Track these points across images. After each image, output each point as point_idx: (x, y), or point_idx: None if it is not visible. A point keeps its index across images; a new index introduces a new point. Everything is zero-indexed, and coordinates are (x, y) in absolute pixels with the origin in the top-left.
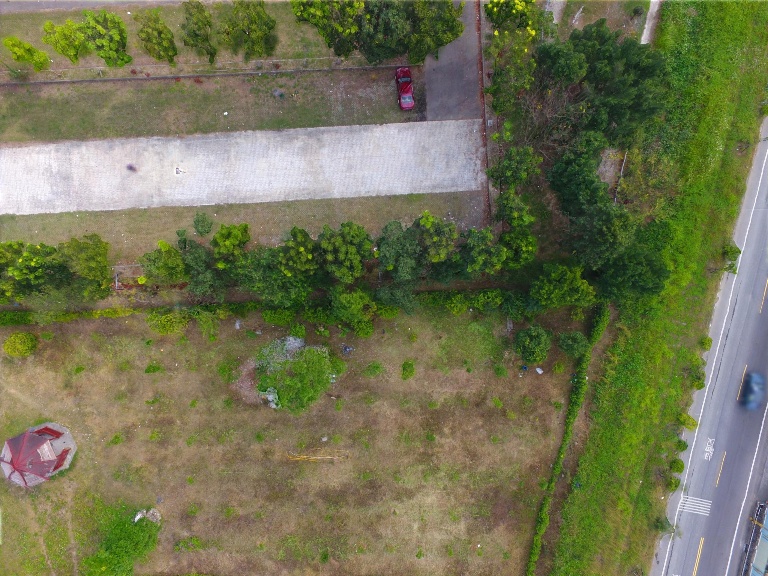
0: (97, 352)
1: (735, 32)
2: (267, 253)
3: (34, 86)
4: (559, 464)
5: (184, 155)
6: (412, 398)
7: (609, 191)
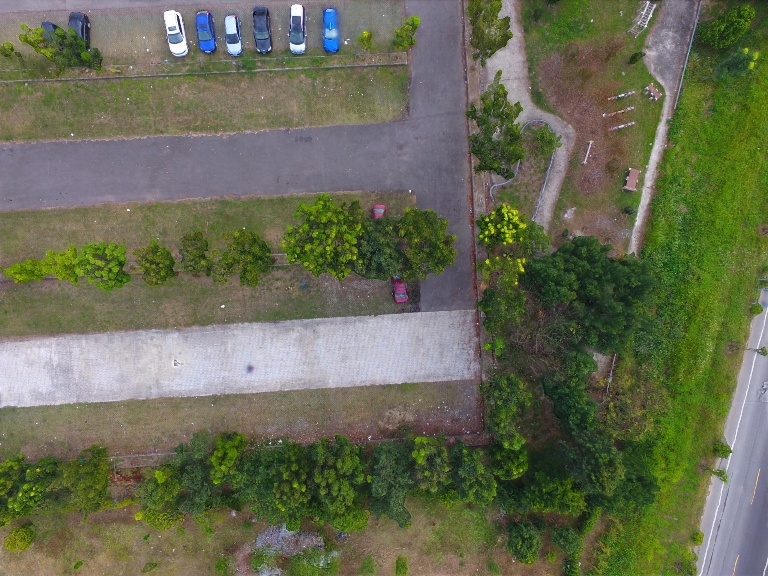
0: (96, 539)
1: (725, 235)
2: (262, 467)
3: (36, 282)
4: None
5: (182, 347)
6: None
7: None
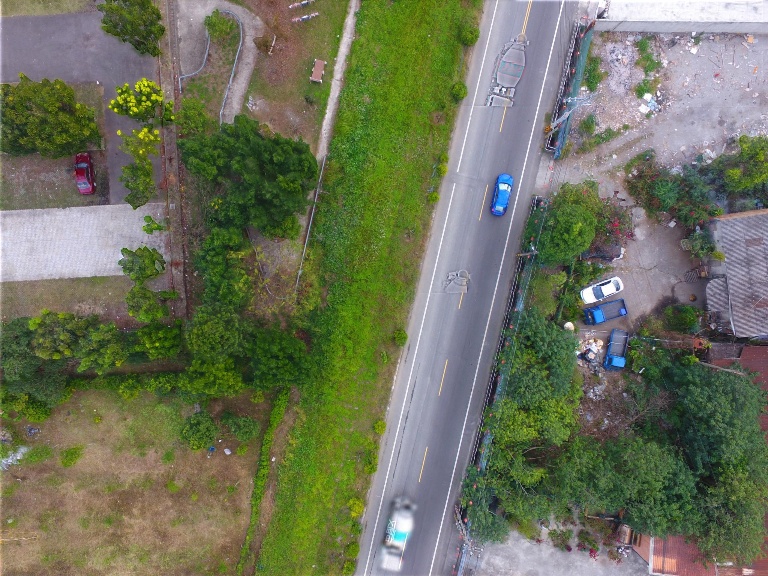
0: None
1: (398, 122)
2: None
3: None
4: (245, 545)
5: None
6: (100, 479)
7: (292, 274)
